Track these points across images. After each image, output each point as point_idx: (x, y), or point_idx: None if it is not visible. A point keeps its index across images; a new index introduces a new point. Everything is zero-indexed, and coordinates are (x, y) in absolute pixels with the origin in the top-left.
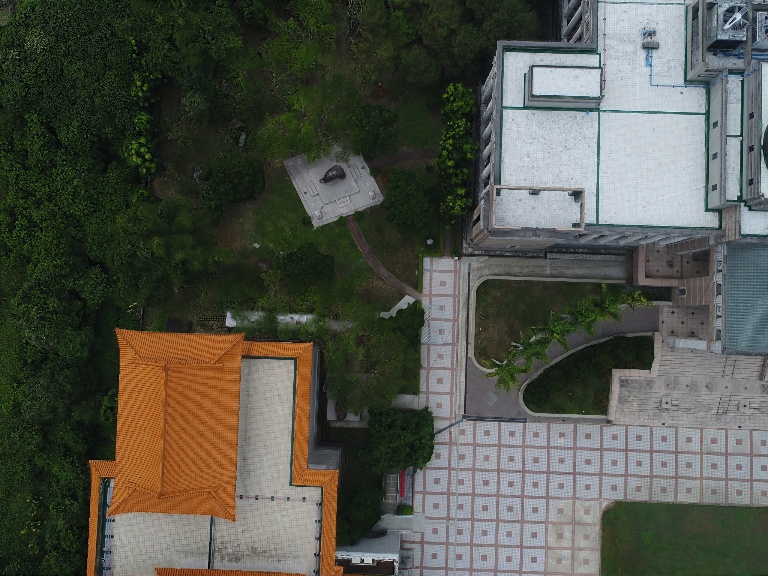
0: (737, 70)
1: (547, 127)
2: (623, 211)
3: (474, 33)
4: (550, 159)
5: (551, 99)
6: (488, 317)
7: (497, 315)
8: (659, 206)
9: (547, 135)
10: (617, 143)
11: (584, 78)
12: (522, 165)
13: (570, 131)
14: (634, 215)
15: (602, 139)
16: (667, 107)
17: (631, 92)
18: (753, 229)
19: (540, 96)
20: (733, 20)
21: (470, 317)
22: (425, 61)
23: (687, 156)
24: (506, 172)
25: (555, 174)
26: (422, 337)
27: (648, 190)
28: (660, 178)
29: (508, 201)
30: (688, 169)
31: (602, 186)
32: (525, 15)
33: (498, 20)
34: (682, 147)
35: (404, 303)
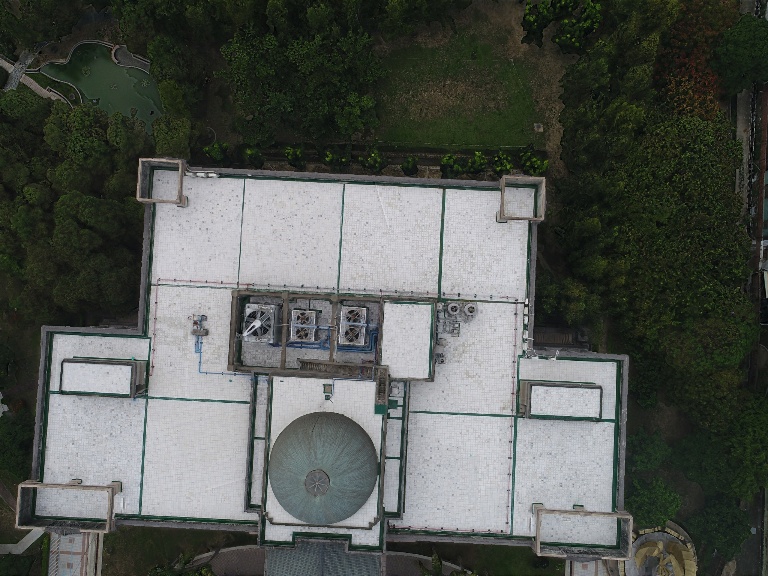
0: (264, 373)
1: (93, 413)
2: (166, 502)
3: (70, 285)
4: (95, 446)
5: (81, 395)
6: (115, 552)
7: (125, 550)
8: (203, 497)
9: (93, 421)
10: (163, 431)
11: (115, 375)
12: (66, 452)
13: (116, 418)
14: (177, 506)
15: (148, 427)
16: (215, 395)
17: (180, 379)
18: (278, 535)
19: (69, 393)
20: (252, 327)
21: (99, 551)
22: (34, 304)
23: (233, 446)
24: (50, 459)
25: (99, 462)
26: (50, 571)
27: (192, 481)
28: (205, 468)
29: (50, 489)
30: (234, 460)
31: (146, 476)
32: (111, 275)
33: (85, 278)
34: (229, 437)
35: (32, 535)
